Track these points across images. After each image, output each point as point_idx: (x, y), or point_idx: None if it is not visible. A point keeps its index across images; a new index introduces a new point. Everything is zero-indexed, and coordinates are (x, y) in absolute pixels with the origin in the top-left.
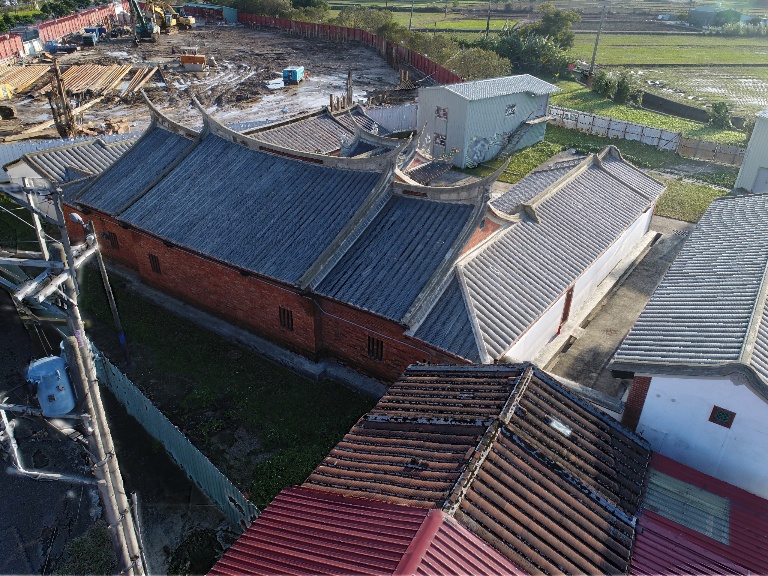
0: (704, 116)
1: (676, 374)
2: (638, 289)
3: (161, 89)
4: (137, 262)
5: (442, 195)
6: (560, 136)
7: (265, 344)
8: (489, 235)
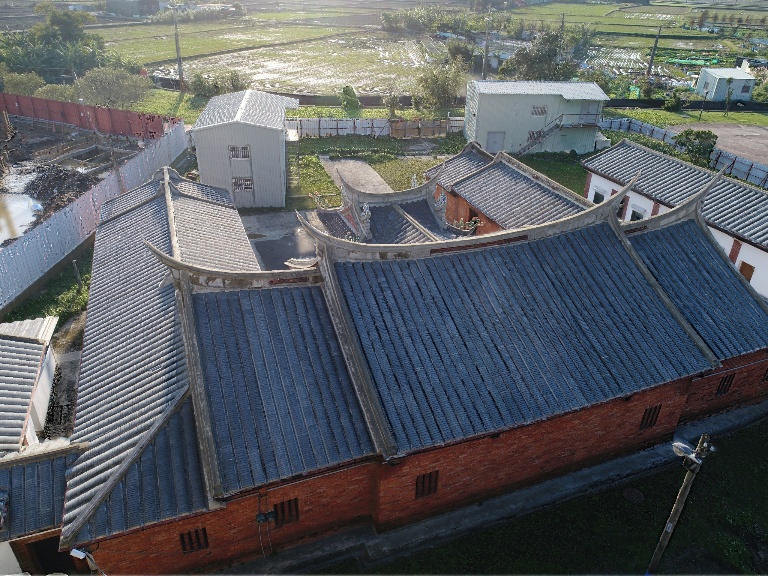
0: (316, 101)
1: None
2: None
3: None
4: None
5: (662, 221)
6: None
7: (619, 464)
8: None
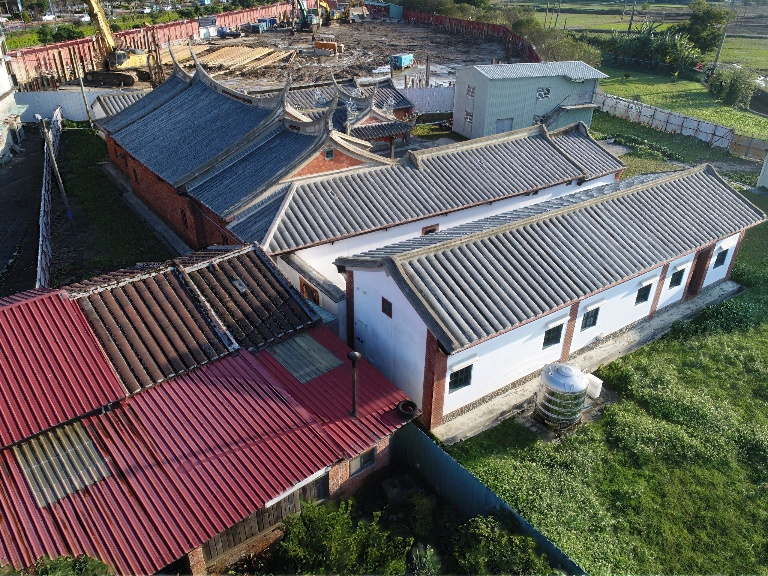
0: None
1: (360, 266)
2: None
3: (279, 67)
4: None
5: (307, 128)
6: (614, 127)
7: (177, 240)
8: (345, 167)
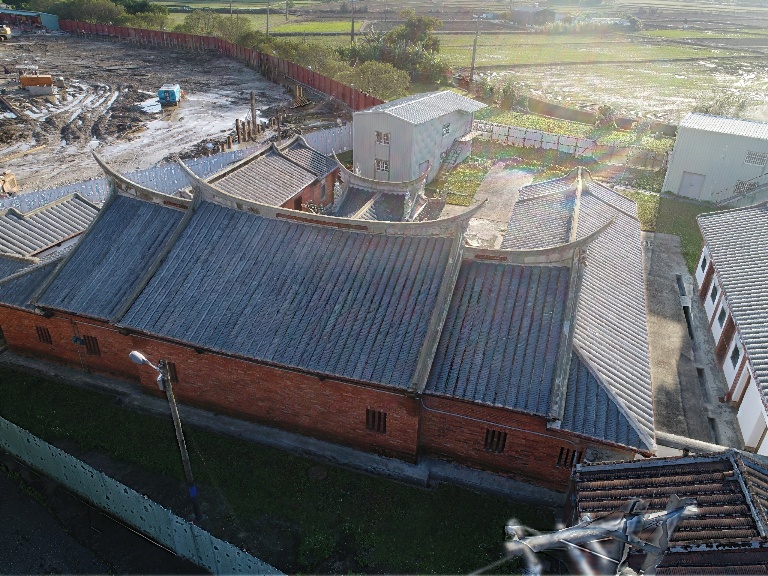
0: (584, 117)
1: None
2: (654, 312)
3: (15, 121)
4: (132, 369)
5: (527, 258)
6: (481, 149)
7: (344, 451)
8: None
